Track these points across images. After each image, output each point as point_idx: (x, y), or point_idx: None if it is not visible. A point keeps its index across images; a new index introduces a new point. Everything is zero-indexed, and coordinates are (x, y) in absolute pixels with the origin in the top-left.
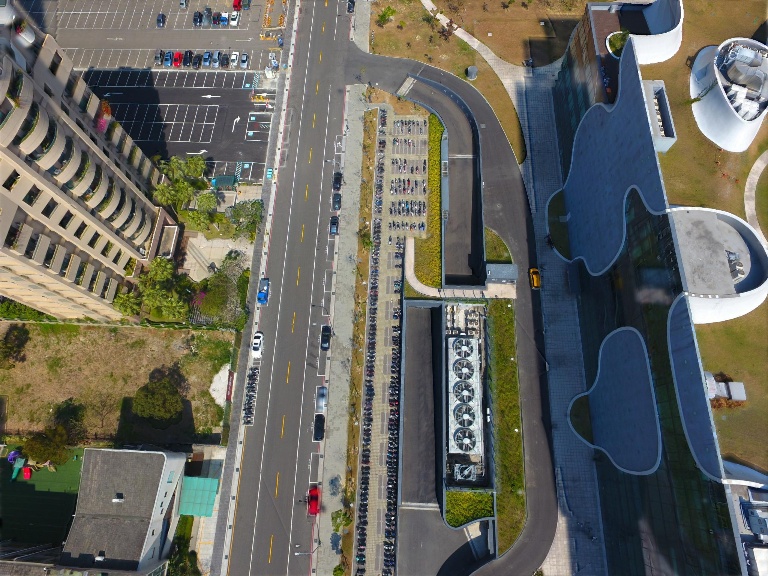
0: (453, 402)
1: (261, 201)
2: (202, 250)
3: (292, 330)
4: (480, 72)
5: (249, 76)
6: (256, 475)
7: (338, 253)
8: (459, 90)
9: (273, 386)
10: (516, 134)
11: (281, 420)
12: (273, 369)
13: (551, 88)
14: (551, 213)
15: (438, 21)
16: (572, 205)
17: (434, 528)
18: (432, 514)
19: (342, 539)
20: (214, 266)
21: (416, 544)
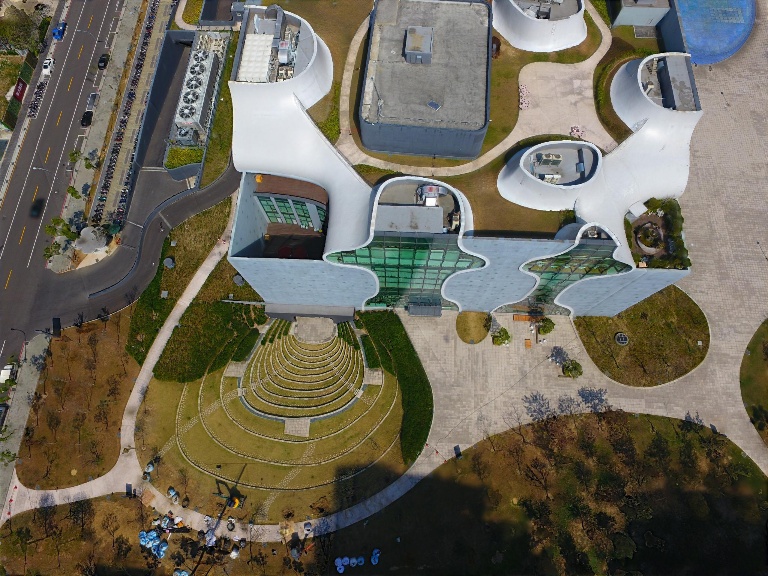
0: (185, 91)
1: None
2: (15, 3)
3: (78, 57)
4: None
5: None
6: (33, 149)
7: None
8: None
9: (56, 93)
10: None
11: (58, 114)
12: (59, 82)
13: None
14: None
15: None
16: None
17: (164, 182)
18: (165, 174)
19: (91, 187)
20: None
21: (148, 192)
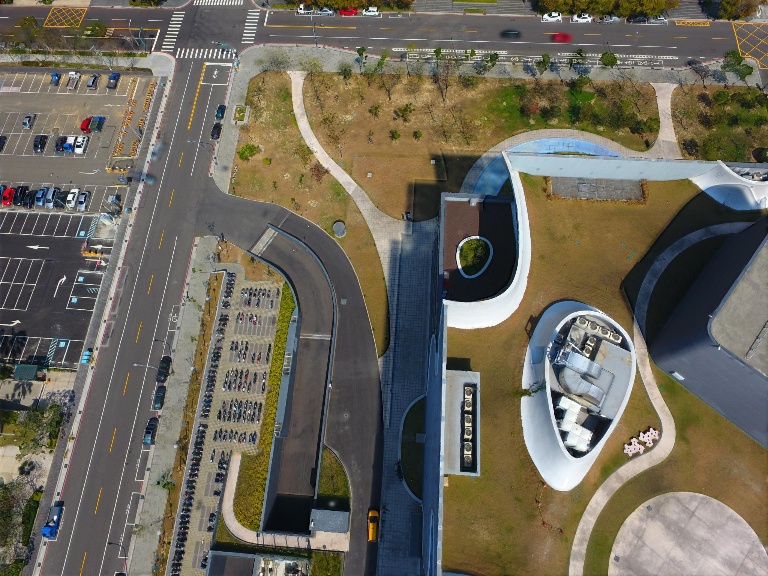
0: None
1: (72, 393)
2: None
3: None
4: (351, 226)
5: (86, 221)
6: None
7: (150, 470)
8: (323, 250)
9: None
10: (381, 315)
11: None
12: None
13: (431, 251)
14: (407, 429)
15: (312, 155)
16: (426, 430)
17: None
18: None
19: None
20: (1, 483)
21: None
